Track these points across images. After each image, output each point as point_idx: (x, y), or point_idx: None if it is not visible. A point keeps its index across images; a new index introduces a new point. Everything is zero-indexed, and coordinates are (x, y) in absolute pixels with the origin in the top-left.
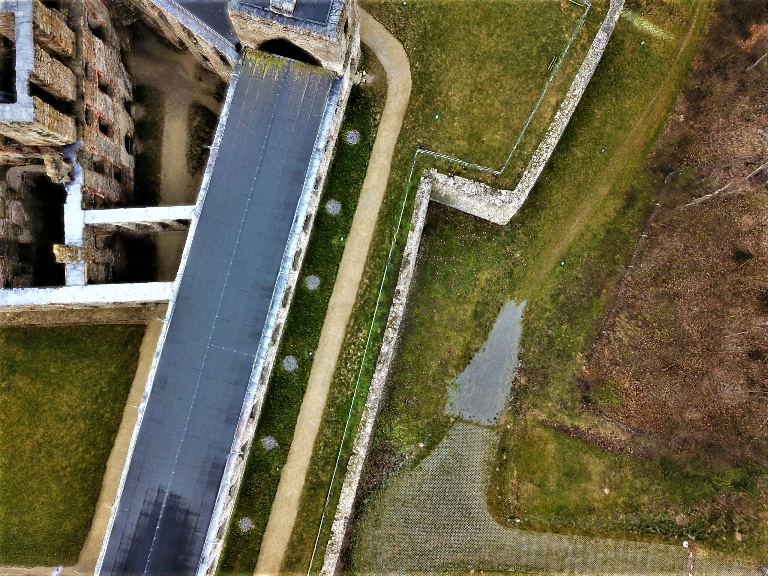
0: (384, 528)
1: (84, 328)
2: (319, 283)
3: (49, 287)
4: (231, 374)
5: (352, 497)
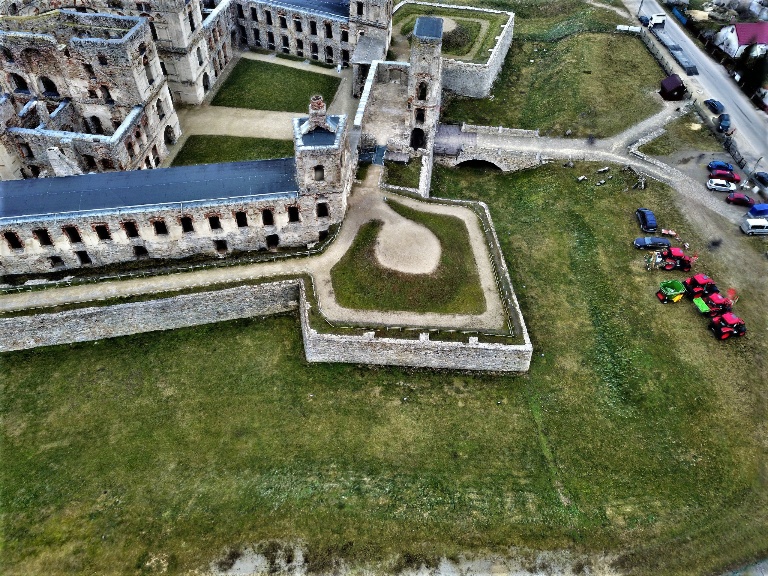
0: None
1: None
2: None
3: (210, 13)
4: None
5: None
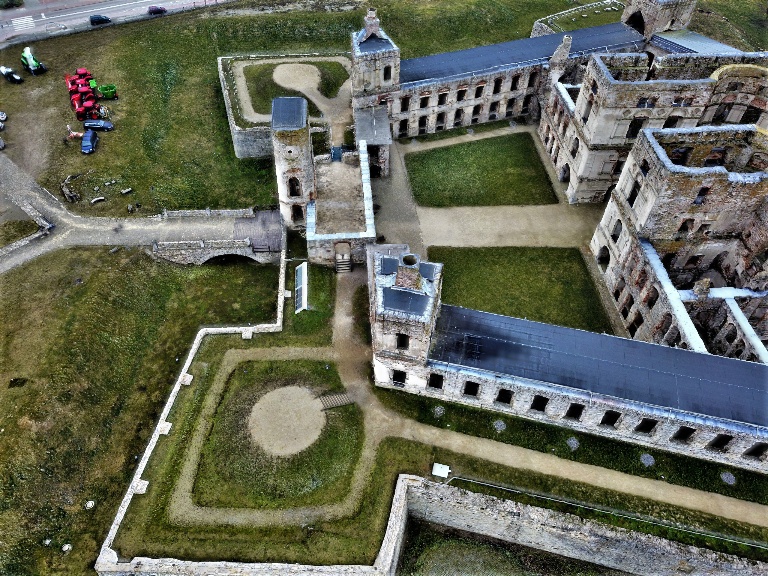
0: (484, 574)
1: (608, 322)
2: (730, 484)
3: None
4: (658, 391)
5: (540, 519)
